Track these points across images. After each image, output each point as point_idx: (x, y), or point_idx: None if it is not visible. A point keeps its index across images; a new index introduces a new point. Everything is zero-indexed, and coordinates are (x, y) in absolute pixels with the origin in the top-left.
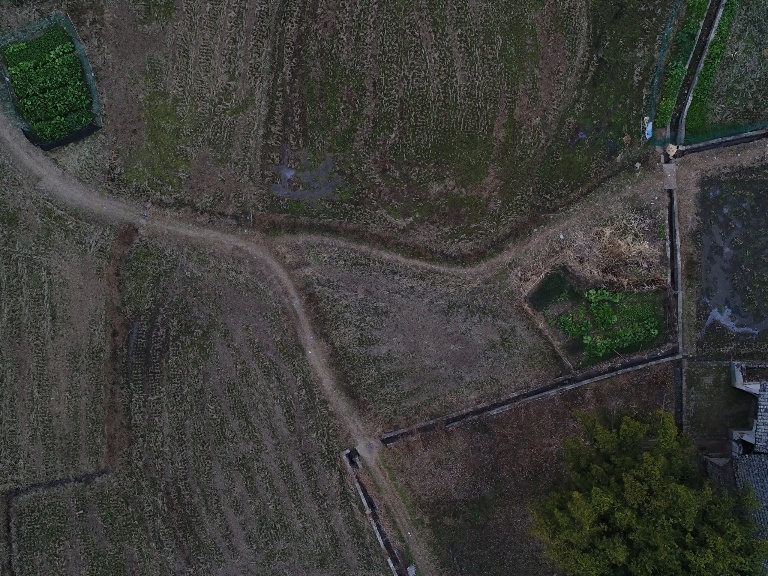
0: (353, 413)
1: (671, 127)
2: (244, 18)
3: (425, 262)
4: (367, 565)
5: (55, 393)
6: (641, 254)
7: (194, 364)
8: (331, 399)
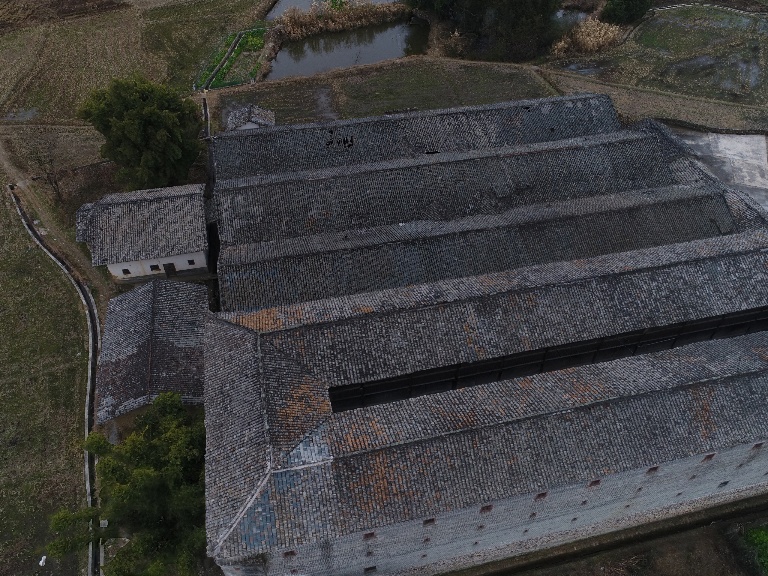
0: (19, 172)
1: (207, 88)
2: (5, 80)
3: (75, 126)
4: (8, 227)
5: None
6: None
7: None
8: None
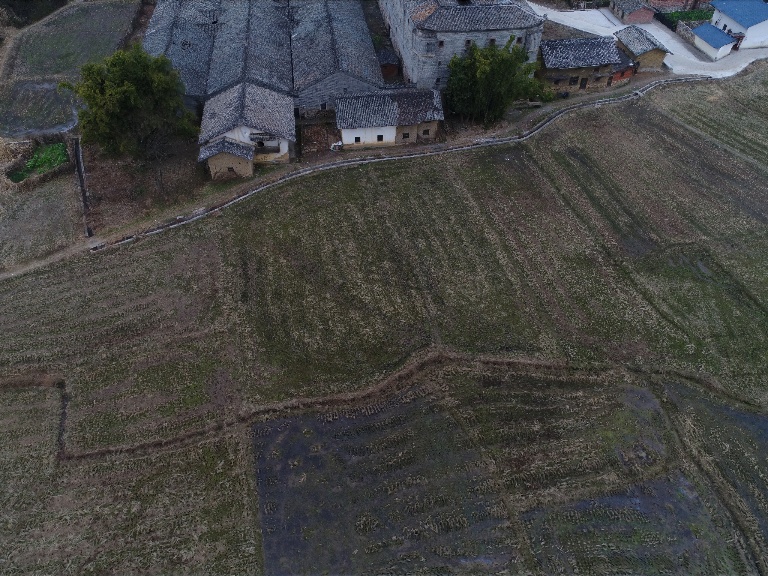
0: None
1: None
2: None
3: None
4: None
5: None
6: (13, 149)
7: None
8: None
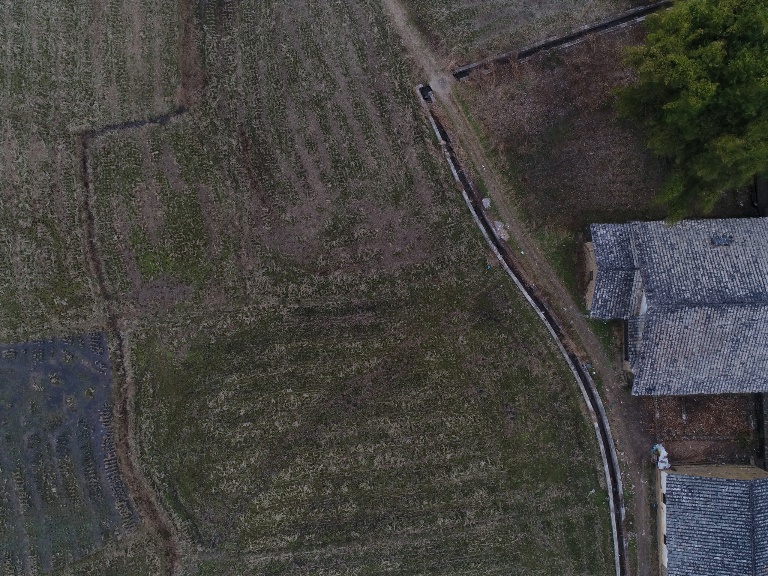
0: (426, 48)
1: None
2: None
3: None
4: (441, 202)
5: (129, 35)
6: None
7: (266, 5)
8: (403, 35)
